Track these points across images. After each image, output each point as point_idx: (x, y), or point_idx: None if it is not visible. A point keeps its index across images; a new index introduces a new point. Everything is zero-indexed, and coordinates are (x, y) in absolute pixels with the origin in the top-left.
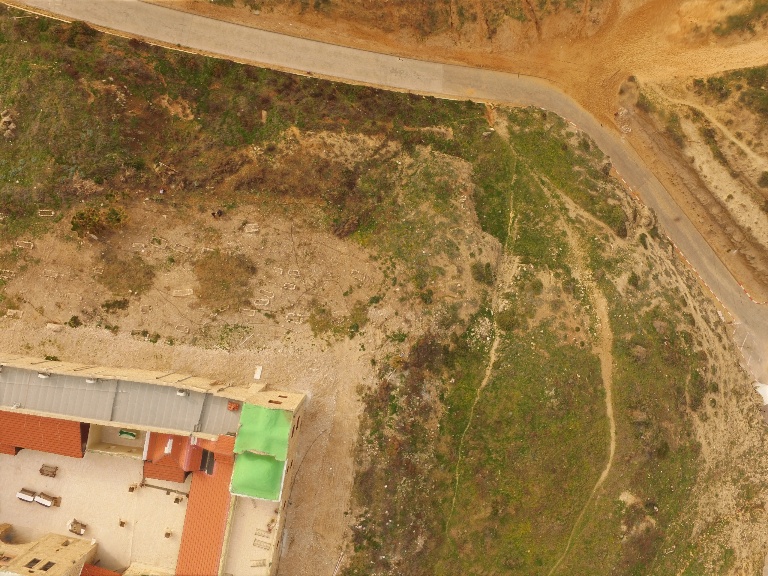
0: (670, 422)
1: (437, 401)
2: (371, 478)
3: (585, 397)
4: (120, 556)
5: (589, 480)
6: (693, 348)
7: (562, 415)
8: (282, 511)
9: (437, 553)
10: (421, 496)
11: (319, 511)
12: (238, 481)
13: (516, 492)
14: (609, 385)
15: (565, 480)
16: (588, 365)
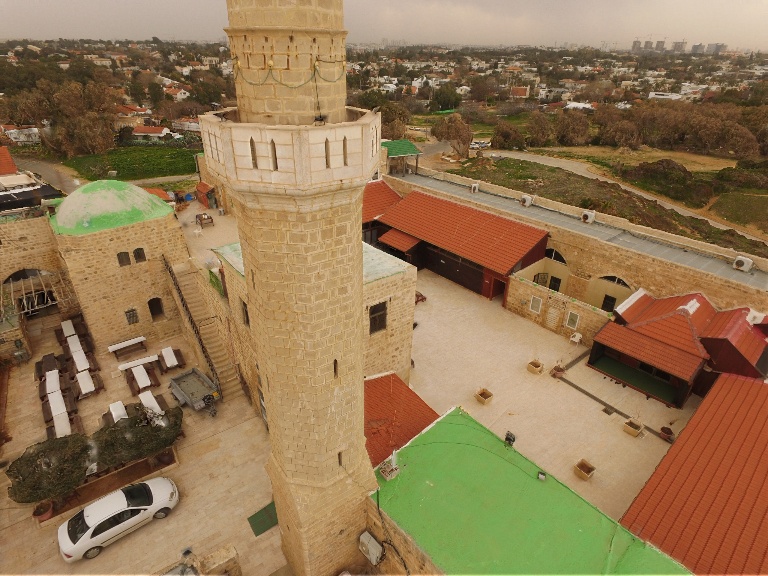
0: None
1: None
2: None
3: None
4: None
5: None
6: None
7: None
8: None
9: None
10: None
11: None
12: None
13: None
14: None
15: None
16: None
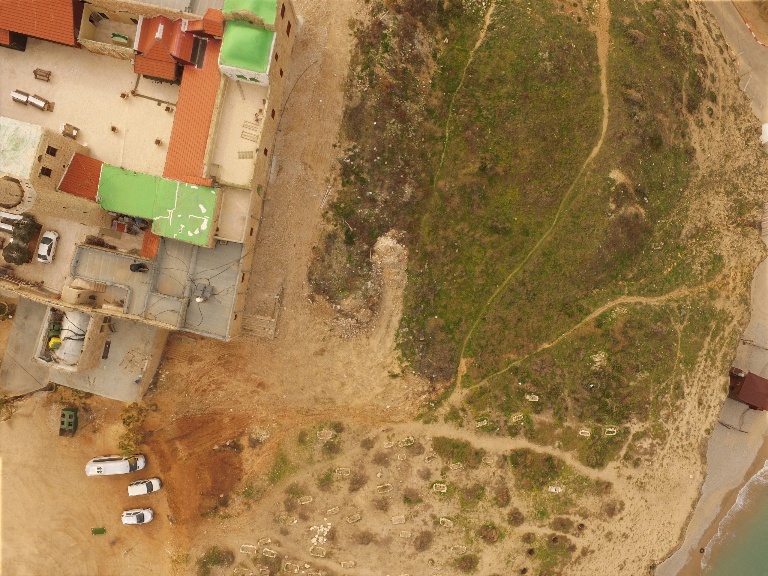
0: (665, 116)
1: (430, 57)
2: (361, 114)
3: (579, 68)
4: (111, 163)
5: (580, 154)
6: (693, 49)
7: (555, 81)
8: (270, 113)
9: (424, 205)
10: (410, 145)
11: (308, 141)
12: (226, 49)
13: (505, 154)
14: (604, 63)
15: (555, 151)
16: (584, 39)
